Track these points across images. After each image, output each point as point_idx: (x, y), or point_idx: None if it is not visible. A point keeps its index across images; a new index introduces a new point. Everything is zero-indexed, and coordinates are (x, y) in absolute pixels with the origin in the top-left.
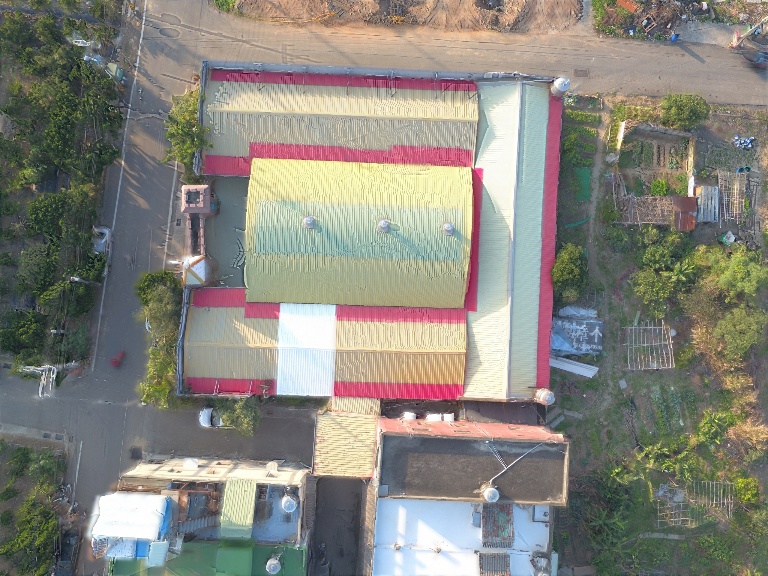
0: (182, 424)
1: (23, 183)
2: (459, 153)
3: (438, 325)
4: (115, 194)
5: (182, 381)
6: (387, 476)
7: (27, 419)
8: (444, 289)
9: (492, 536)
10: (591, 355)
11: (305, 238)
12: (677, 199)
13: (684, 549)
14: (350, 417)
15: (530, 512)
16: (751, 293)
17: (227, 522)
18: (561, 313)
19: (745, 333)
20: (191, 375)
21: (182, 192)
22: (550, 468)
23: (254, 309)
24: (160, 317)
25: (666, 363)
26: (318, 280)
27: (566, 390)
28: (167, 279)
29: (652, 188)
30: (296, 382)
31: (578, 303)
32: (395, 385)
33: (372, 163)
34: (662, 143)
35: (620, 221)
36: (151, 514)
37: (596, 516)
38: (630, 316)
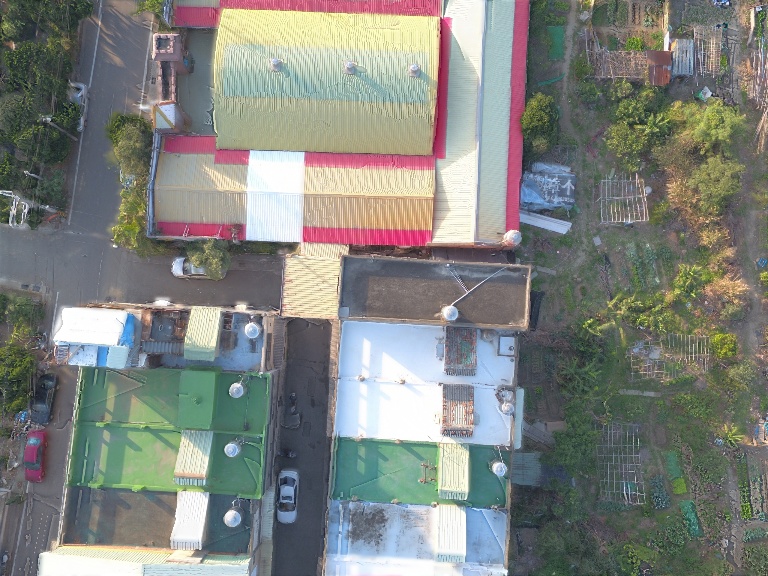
0: (155, 276)
1: (2, 40)
2: (427, 1)
3: (406, 169)
4: (92, 54)
5: (152, 224)
6: (348, 299)
7: (5, 271)
8: (411, 131)
9: (454, 363)
10: (563, 208)
11: (273, 83)
12: (651, 53)
13: (660, 406)
14: (318, 260)
15: (495, 346)
16: (725, 138)
17: (190, 345)
18: (534, 170)
19: (719, 180)
20: (162, 220)
21: (153, 40)
22: (512, 293)
23: (224, 156)
24: (129, 155)
25: (640, 216)
26: (283, 115)
27: (539, 246)
28: (137, 121)
29: (627, 45)
30: (265, 227)
31: (550, 156)
32: (363, 231)
33: (341, 13)
34: (637, 1)
35: (593, 75)
36: (111, 323)
37: (567, 365)
38: (604, 173)
